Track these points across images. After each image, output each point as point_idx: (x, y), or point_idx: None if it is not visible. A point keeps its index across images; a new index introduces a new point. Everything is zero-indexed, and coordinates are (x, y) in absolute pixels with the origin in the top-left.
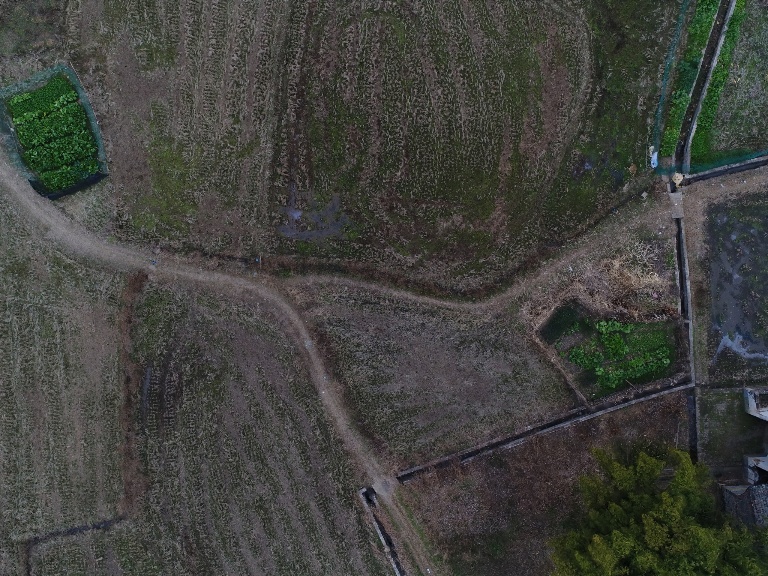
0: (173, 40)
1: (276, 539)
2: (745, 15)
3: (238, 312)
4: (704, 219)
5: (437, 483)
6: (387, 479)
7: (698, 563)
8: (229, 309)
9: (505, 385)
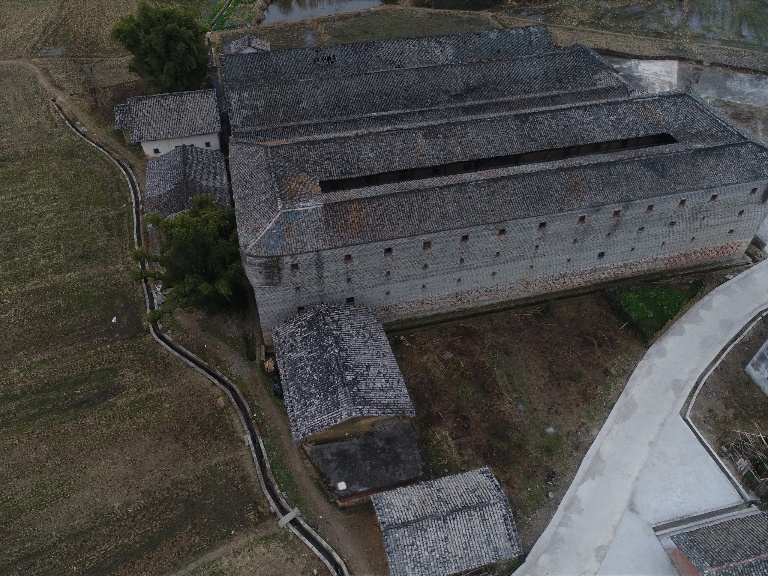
0: (5, 24)
1: (0, 116)
2: (234, 8)
3: (7, 68)
4: (220, 38)
5: (90, 94)
6: (65, 96)
7: (156, 8)
8: (3, 68)
9: (130, 74)
